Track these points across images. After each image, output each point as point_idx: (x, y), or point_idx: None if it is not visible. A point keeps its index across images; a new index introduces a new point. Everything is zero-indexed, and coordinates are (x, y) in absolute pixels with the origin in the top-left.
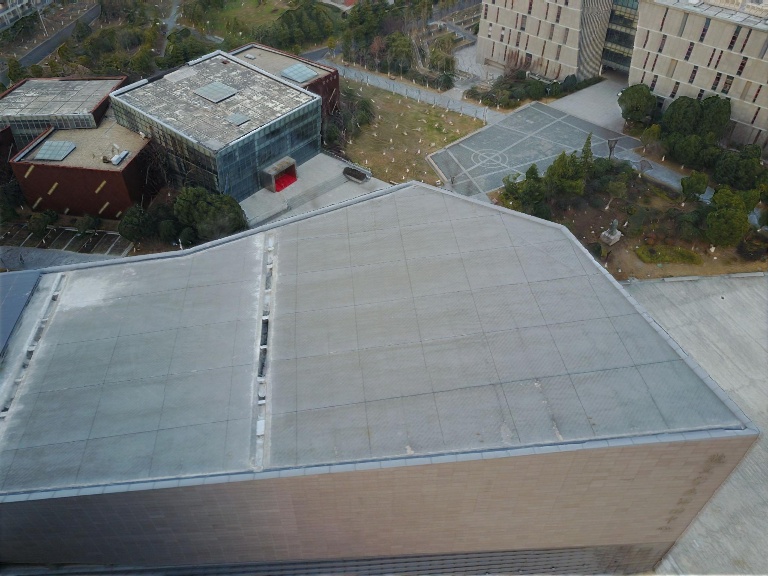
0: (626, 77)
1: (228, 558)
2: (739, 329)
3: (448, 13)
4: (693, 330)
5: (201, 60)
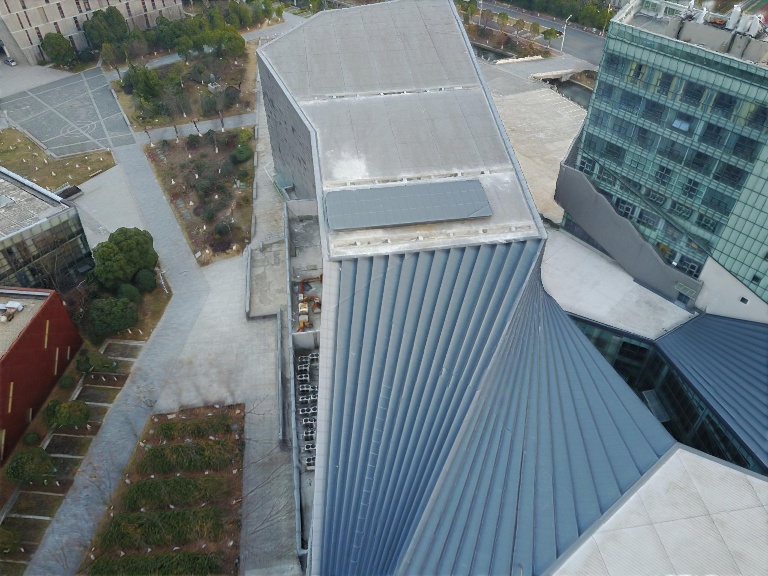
0: None
1: None
2: None
3: None
4: None
5: None
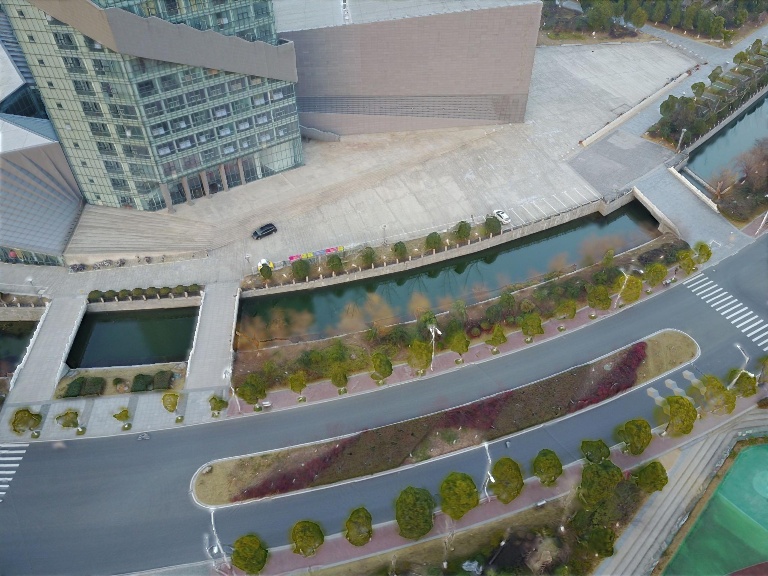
0: None
1: (330, 92)
2: (597, 61)
3: None
4: (571, 61)
5: None
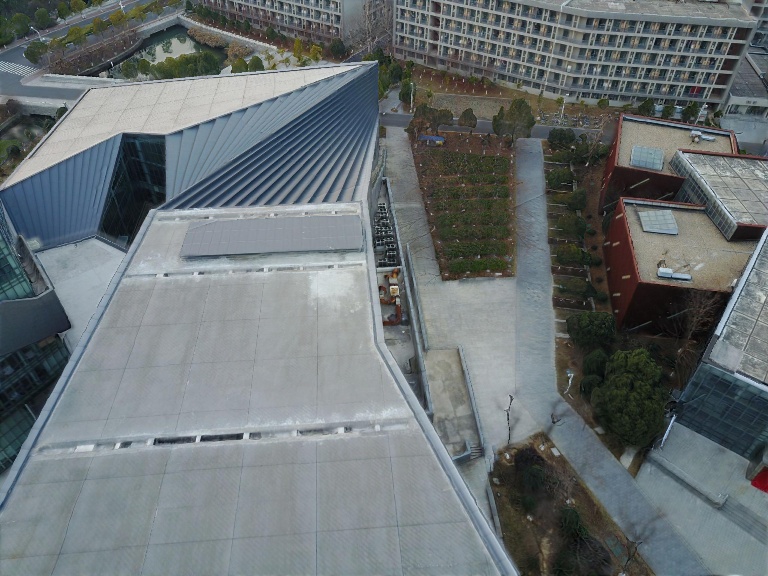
0: None
1: None
2: None
3: None
4: None
5: None
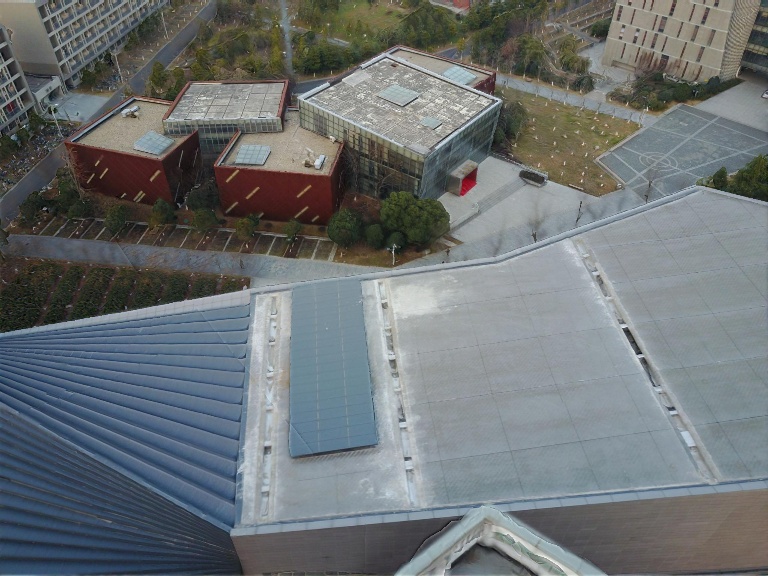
0: (764, 79)
1: (612, 570)
2: None
3: (560, 14)
4: None
5: (371, 63)
